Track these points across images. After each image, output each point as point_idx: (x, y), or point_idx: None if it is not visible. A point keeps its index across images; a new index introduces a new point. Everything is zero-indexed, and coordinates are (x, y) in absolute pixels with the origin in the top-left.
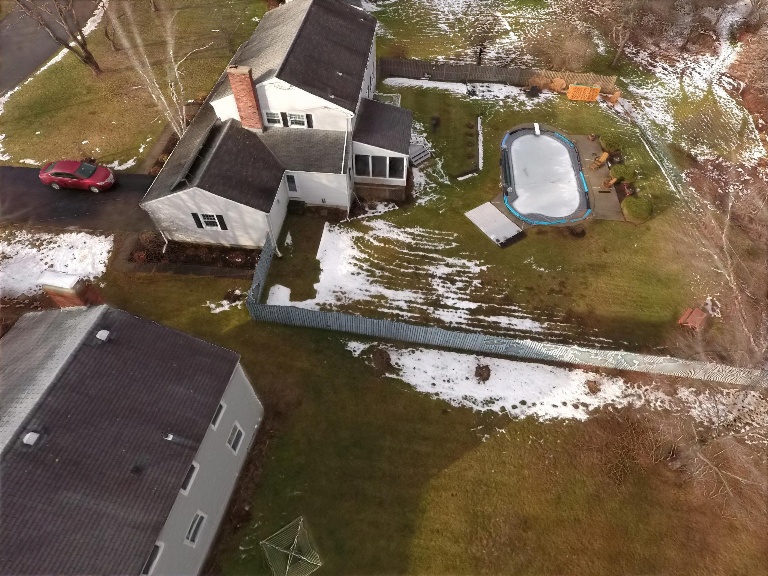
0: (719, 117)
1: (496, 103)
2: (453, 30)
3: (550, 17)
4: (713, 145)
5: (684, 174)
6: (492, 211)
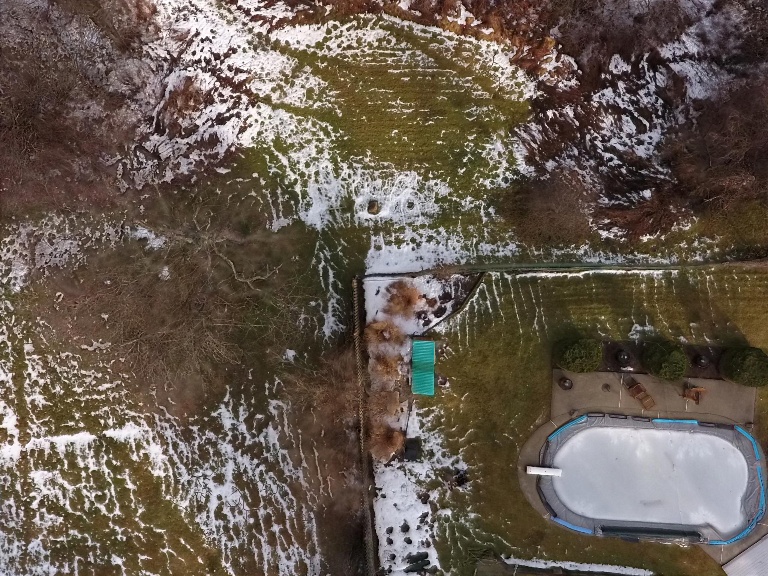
0: (394, 80)
1: (448, 522)
2: (122, 570)
3: (2, 324)
4: (483, 129)
5: (602, 232)
6: (742, 565)
